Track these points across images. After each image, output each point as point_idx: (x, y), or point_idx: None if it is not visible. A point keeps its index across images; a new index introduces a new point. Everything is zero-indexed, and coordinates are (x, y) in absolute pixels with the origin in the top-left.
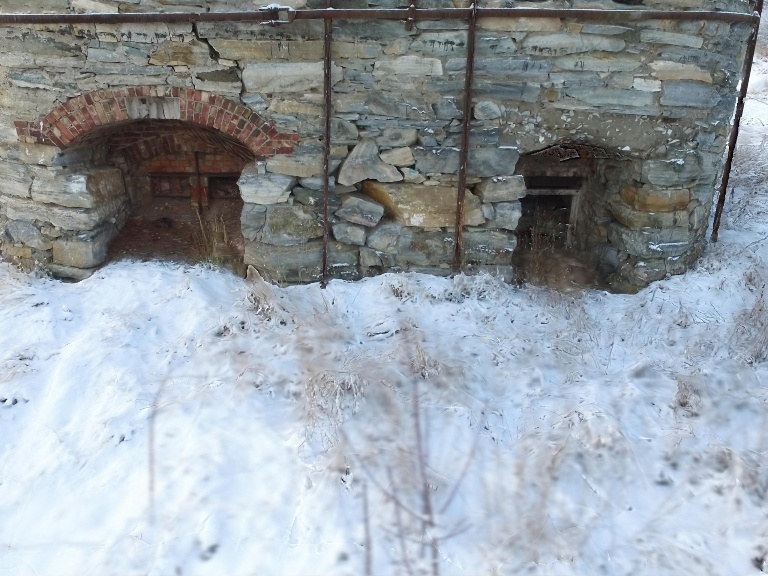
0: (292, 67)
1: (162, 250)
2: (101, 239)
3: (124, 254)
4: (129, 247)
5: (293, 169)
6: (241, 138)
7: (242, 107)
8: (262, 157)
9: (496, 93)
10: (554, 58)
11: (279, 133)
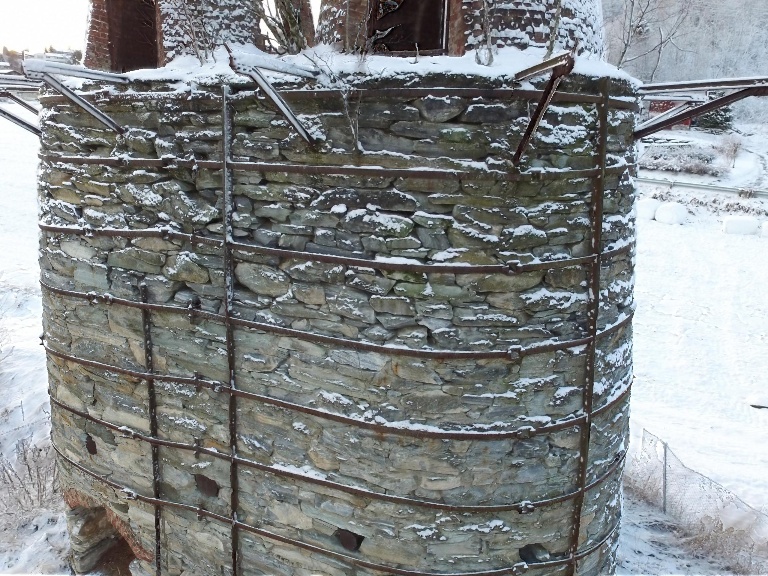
0: (149, 516)
1: (123, 569)
2: (93, 555)
3: (103, 566)
4: (112, 559)
5: (152, 572)
6: (129, 543)
7: (128, 527)
8: (138, 558)
9: (258, 574)
10: (294, 567)
11: (144, 549)
